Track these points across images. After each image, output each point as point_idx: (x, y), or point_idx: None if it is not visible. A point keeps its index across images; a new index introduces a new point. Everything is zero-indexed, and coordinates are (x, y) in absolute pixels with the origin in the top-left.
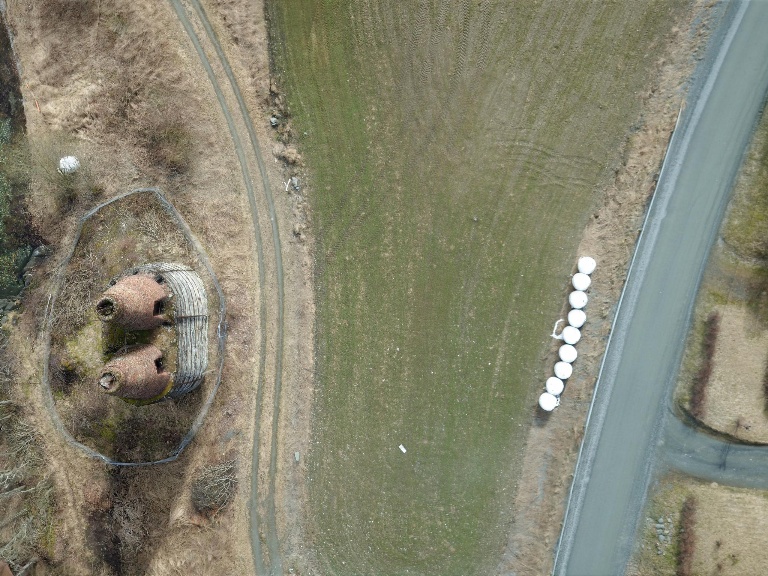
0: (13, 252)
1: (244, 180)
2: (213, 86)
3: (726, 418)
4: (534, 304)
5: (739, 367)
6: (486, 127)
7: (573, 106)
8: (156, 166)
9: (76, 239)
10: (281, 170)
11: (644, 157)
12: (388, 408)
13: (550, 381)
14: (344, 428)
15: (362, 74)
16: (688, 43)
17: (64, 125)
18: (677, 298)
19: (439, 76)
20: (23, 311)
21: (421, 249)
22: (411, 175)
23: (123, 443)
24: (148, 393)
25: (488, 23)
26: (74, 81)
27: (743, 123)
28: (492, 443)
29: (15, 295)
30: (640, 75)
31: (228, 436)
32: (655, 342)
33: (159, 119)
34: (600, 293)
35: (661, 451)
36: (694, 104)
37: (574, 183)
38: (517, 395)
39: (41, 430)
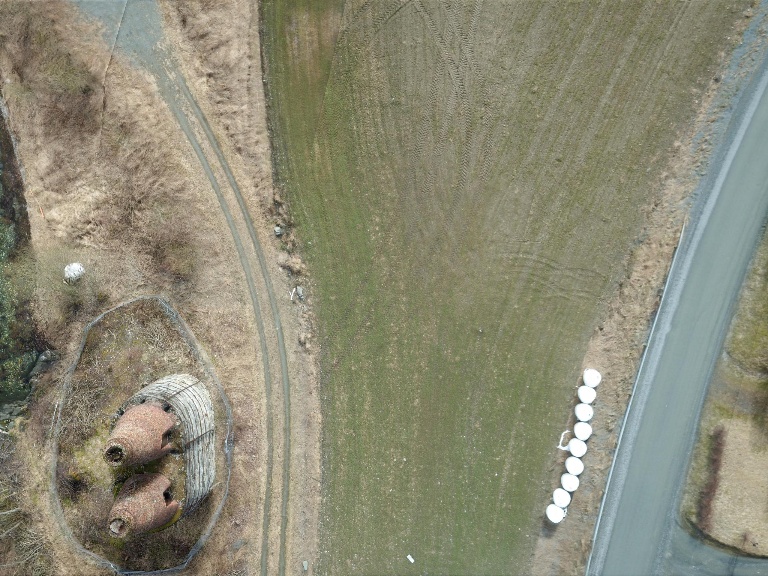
0: (19, 357)
1: (249, 290)
2: (217, 196)
3: (733, 532)
4: (540, 415)
5: (745, 481)
6: (490, 239)
7: (576, 219)
8: (161, 273)
9: (82, 345)
10: (286, 279)
11: (648, 271)
12: (396, 518)
13: (557, 493)
14: (352, 537)
15: (365, 185)
16: (690, 157)
17: (68, 232)
18: (683, 412)
19: (442, 188)
20: (30, 417)
21: (426, 360)
22: (415, 286)
23: (131, 551)
24: (157, 525)
25: (490, 136)
26: (78, 187)
27: (746, 238)
28: (500, 553)
29: (22, 400)
30: (643, 189)
31: (236, 546)
32: (661, 455)
33: (163, 231)
34: (606, 405)
35: (669, 563)
36: (697, 219)
37: (578, 295)
38: (524, 506)
39: (49, 537)
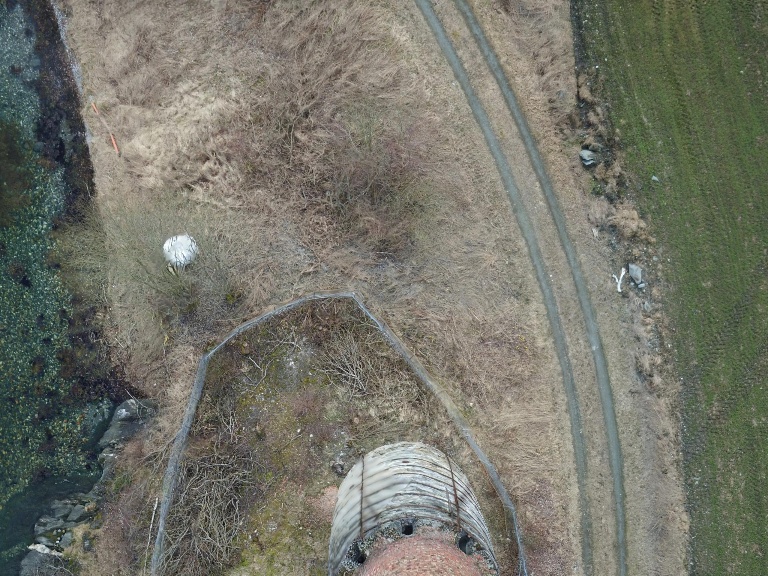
0: (77, 412)
1: (534, 274)
2: (463, 93)
3: None
4: None
5: None
6: None
7: None
8: (345, 248)
9: (197, 388)
10: (605, 251)
11: None
12: None
13: None
14: None
15: None
16: None
17: (166, 178)
18: None
19: None
20: (101, 524)
21: None
22: None
23: None
24: None
25: None
26: (182, 95)
27: None
28: None
29: (84, 492)
30: None
31: None
32: None
33: (367, 162)
34: None
35: None
36: None
37: None
38: None
39: None
